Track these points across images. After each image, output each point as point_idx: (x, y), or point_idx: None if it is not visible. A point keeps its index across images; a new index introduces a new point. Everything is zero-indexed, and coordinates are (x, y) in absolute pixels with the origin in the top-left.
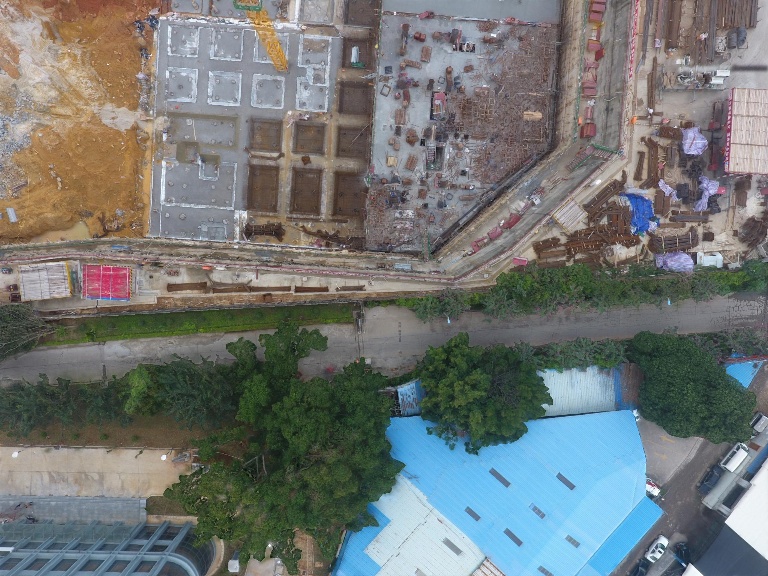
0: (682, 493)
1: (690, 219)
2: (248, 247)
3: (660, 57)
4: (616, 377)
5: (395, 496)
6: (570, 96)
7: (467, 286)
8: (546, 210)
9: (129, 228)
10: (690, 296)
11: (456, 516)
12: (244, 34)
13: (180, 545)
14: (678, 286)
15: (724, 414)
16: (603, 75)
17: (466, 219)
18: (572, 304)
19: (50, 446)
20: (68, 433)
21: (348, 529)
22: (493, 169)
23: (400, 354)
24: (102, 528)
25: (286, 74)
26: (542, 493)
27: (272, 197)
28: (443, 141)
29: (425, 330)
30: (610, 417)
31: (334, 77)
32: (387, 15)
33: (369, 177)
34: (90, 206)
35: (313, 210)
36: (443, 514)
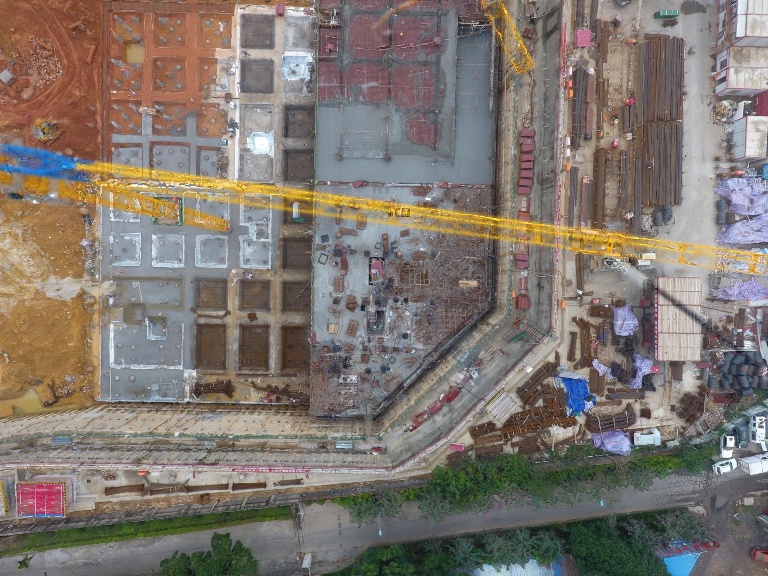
0: None
1: (626, 397)
2: (189, 433)
3: (587, 237)
4: (556, 569)
5: None
6: (504, 265)
7: (405, 474)
8: (481, 394)
9: (79, 392)
10: (626, 487)
11: None
12: (185, 197)
13: None
14: (614, 474)
15: None
16: (534, 250)
17: (410, 381)
18: (507, 500)
19: None
20: None
21: None
22: (434, 330)
23: (341, 547)
24: None
25: (228, 233)
26: None
27: (221, 353)
28: (383, 305)
29: None
30: None
31: (276, 234)
32: (321, 185)
33: (310, 346)
34: (39, 375)
35: (262, 365)
36: None
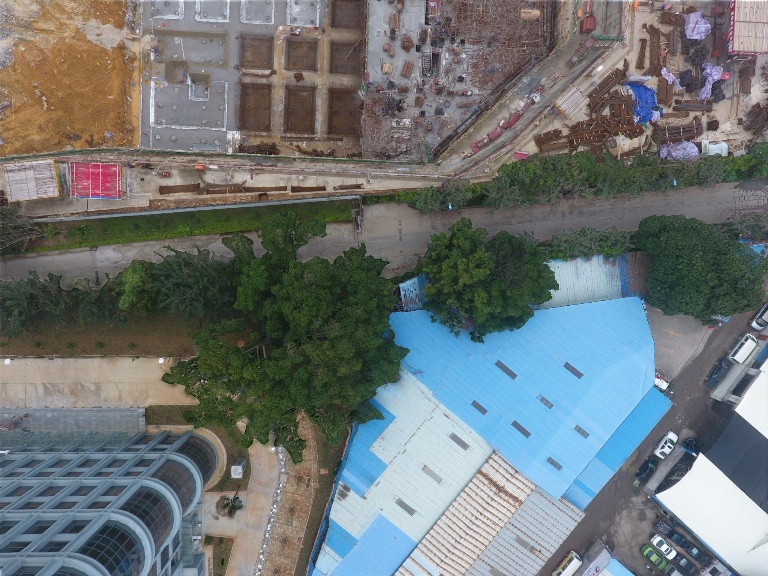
0: (691, 388)
1: (694, 108)
2: (242, 154)
3: None
4: (622, 267)
5: (400, 392)
6: None
7: None
8: (547, 102)
9: None
10: (696, 180)
11: (463, 410)
12: None
13: (181, 448)
14: (683, 172)
15: (735, 280)
16: None
17: (464, 127)
18: (576, 192)
19: (44, 356)
20: (62, 343)
21: (353, 419)
22: (491, 75)
23: (401, 253)
24: (100, 438)
25: None
26: (550, 383)
27: (265, 117)
28: (439, 46)
29: (426, 228)
30: (617, 304)
31: None
32: None
33: (364, 85)
34: (78, 128)
35: (307, 129)
36: (449, 409)
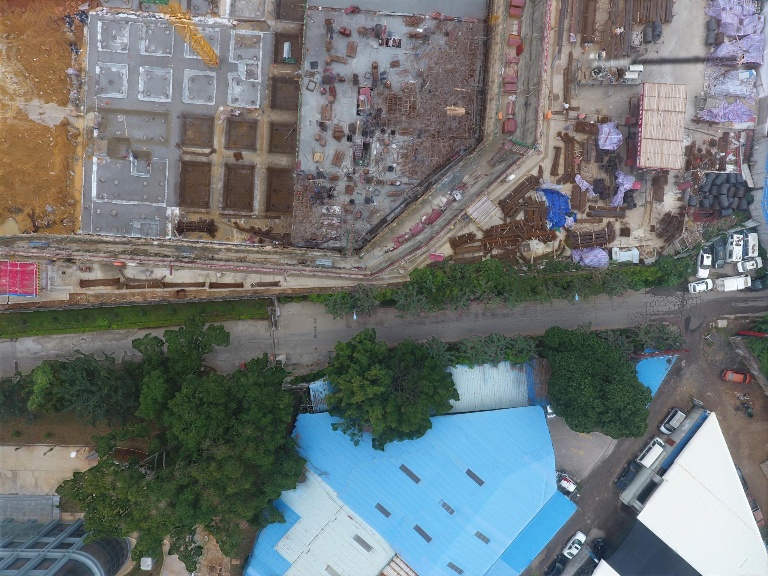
0: (600, 489)
1: (607, 214)
2: (168, 243)
3: (576, 52)
4: (529, 373)
5: (305, 493)
6: (492, 91)
7: (383, 282)
8: (463, 205)
9: (60, 225)
10: (601, 291)
11: (366, 512)
12: (175, 29)
13: (88, 543)
14: (591, 281)
15: (619, 409)
16: (522, 70)
17: (394, 215)
18: (483, 299)
19: None
20: None
21: (251, 526)
22: (420, 165)
23: (315, 350)
24: (14, 526)
25: (217, 69)
26: (452, 489)
27: (205, 193)
28: (370, 137)
29: (341, 326)
30: (520, 413)
31: (266, 73)
32: (312, 10)
33: (295, 173)
34: (19, 202)
35: (246, 206)
36: (353, 511)
